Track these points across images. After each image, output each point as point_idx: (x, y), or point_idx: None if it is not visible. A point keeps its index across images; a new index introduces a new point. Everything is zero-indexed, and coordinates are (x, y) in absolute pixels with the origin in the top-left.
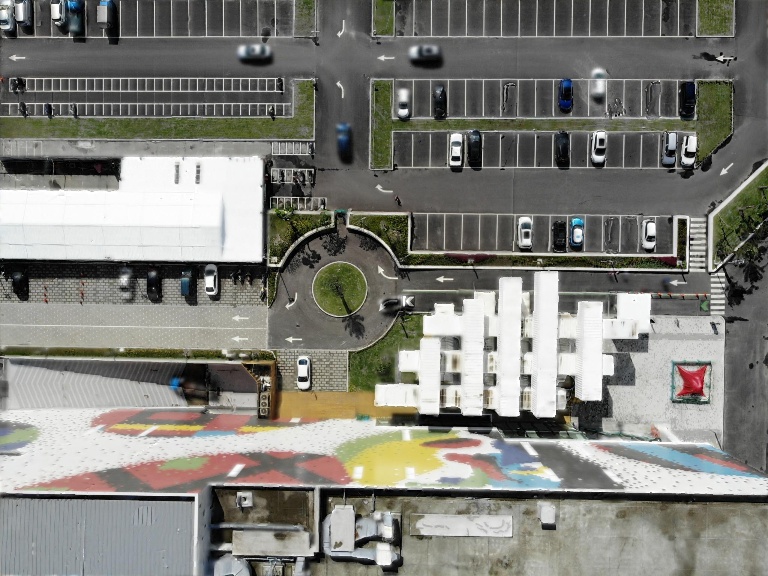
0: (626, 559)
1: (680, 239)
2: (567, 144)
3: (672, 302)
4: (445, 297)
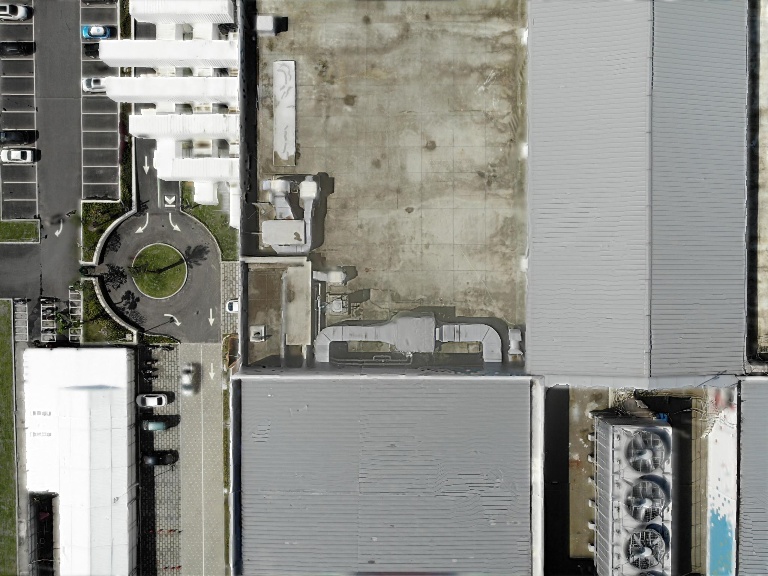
0: None
1: None
2: (6, 44)
3: None
4: None
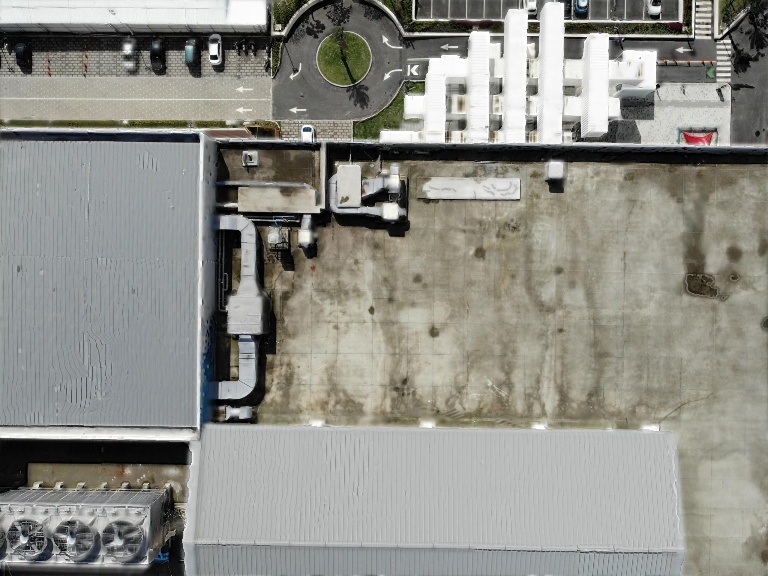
0: (634, 222)
1: (686, 4)
2: None
3: (678, 69)
4: None
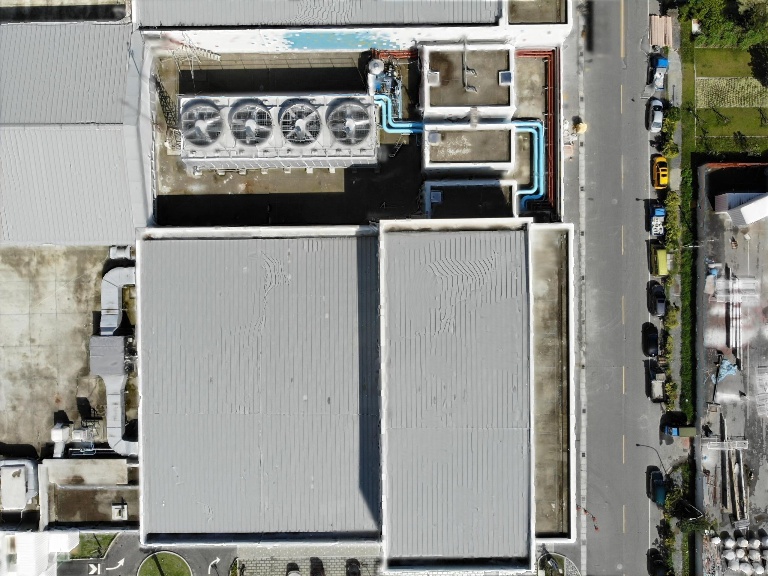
0: None
1: None
2: None
3: None
4: (57, 575)
